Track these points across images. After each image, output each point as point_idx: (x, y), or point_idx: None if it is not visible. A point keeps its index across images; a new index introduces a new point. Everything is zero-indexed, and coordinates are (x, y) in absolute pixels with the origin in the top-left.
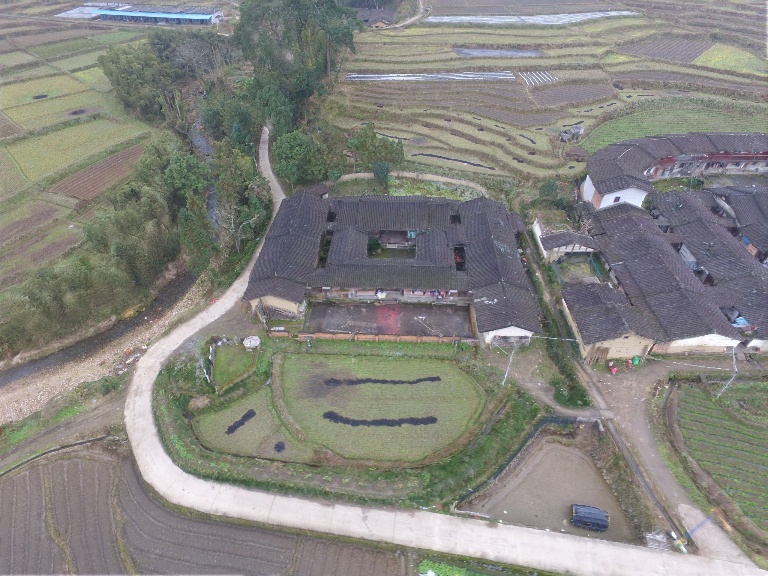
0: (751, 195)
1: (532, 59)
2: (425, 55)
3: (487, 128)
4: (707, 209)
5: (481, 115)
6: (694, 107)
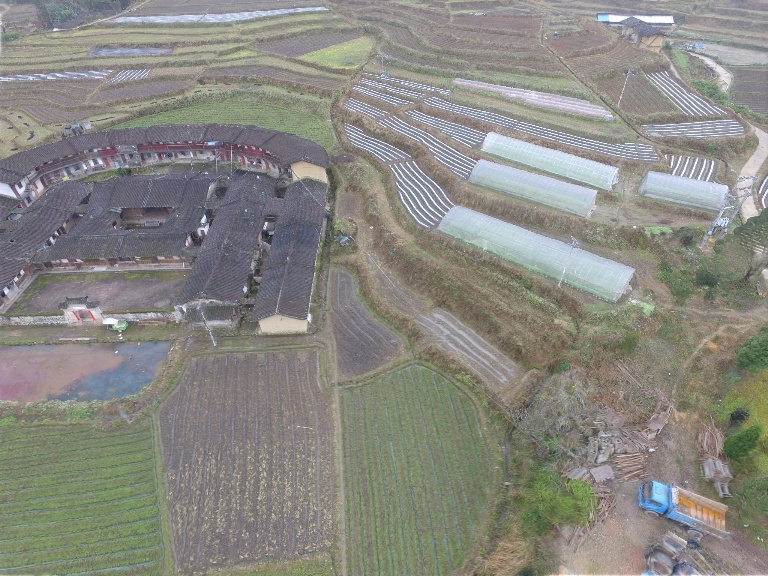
0: (115, 183)
1: (152, 57)
2: (53, 56)
3: (14, 126)
4: (80, 197)
5: (27, 113)
6: (252, 100)
